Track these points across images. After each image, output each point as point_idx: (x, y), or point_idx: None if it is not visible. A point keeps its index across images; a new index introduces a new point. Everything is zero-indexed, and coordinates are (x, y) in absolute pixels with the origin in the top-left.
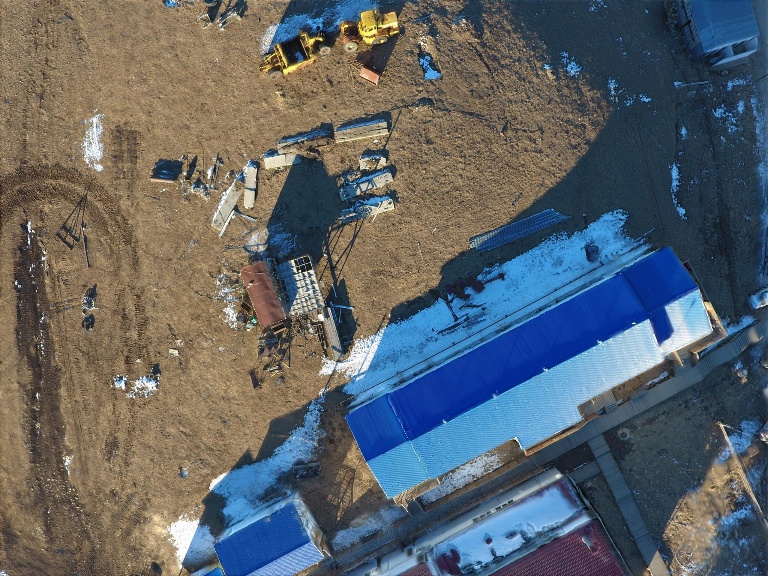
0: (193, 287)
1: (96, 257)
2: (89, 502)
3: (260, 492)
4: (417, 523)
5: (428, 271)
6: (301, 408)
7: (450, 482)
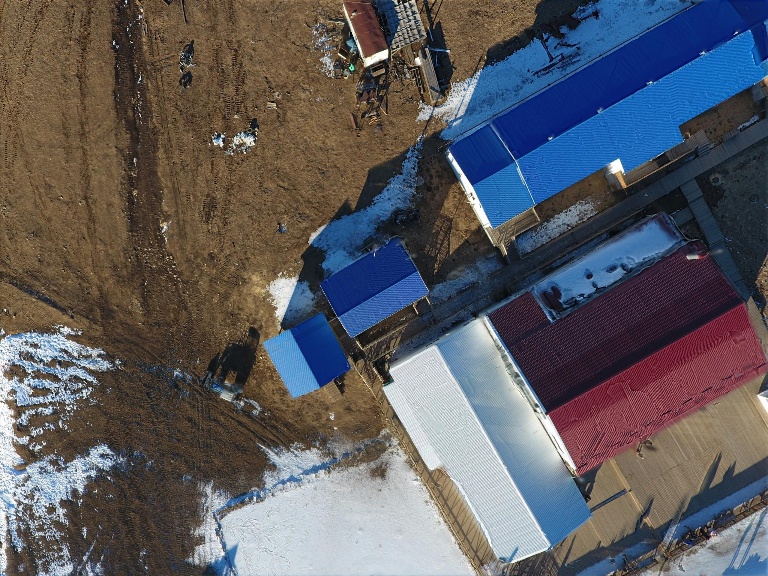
0: (290, 38)
1: (193, 12)
2: (187, 268)
3: (359, 243)
4: (513, 275)
5: (523, 10)
6: (399, 155)
7: (545, 232)
